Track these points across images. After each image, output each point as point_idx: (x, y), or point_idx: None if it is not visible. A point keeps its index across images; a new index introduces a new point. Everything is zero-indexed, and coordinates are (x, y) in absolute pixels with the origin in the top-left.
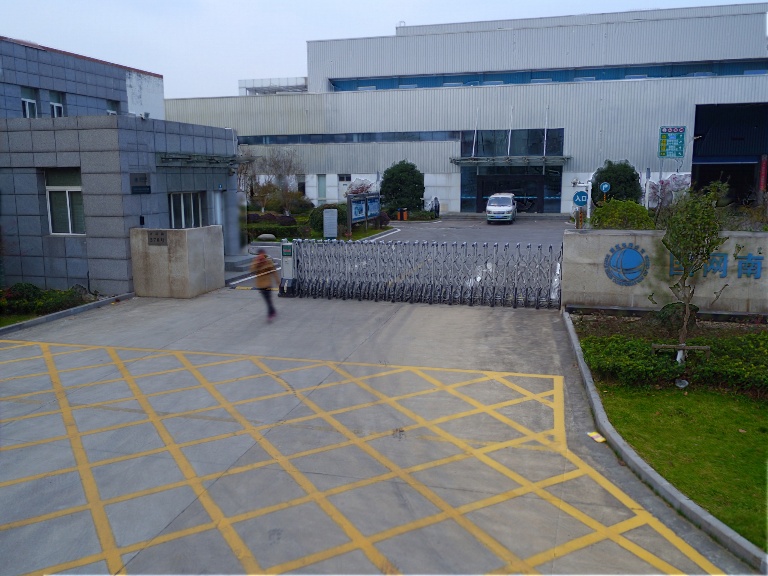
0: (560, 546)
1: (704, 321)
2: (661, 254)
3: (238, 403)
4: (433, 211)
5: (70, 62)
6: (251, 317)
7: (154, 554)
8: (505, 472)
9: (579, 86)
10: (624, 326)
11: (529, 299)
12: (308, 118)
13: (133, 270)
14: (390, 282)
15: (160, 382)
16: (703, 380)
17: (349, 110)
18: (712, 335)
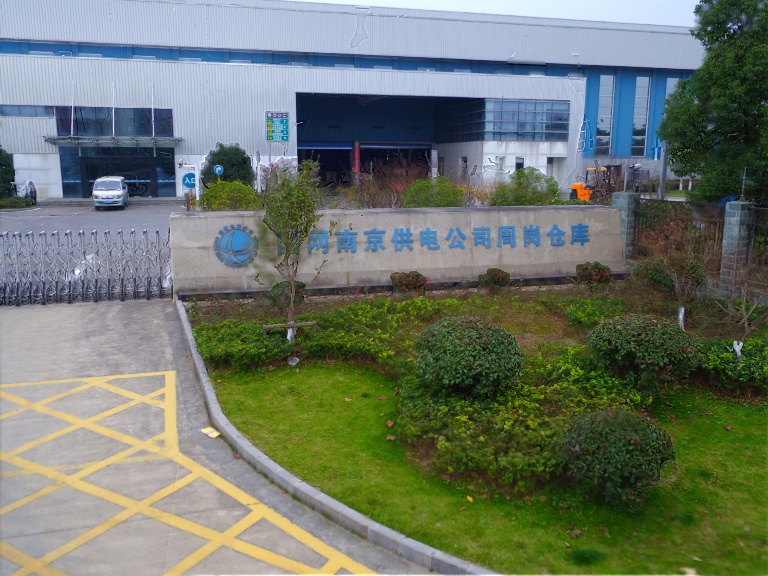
0: (169, 571)
1: (312, 296)
2: (268, 234)
3: None
4: (28, 197)
5: None
6: None
7: None
8: (105, 496)
9: (184, 66)
10: (237, 309)
11: (138, 290)
12: None
13: None
14: None
15: None
16: (312, 355)
17: None
18: (319, 309)
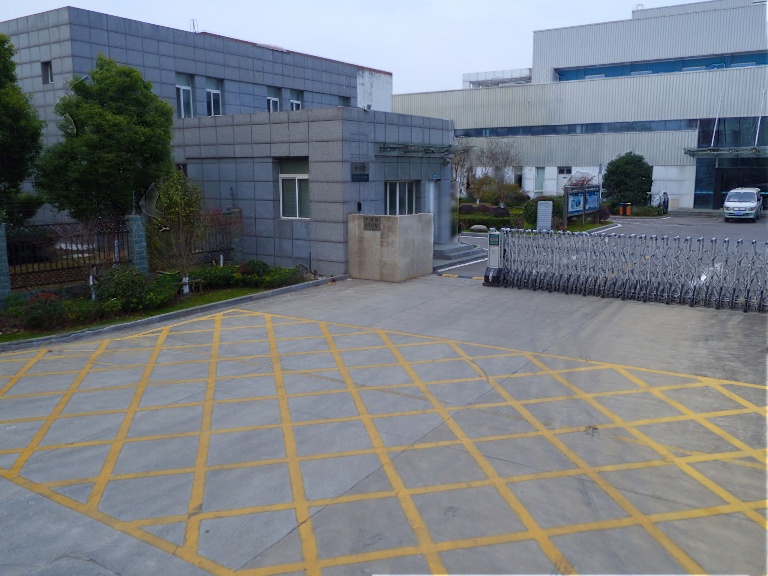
0: None
1: None
2: None
3: (431, 383)
4: (661, 206)
5: (309, 62)
6: (454, 303)
7: (337, 511)
8: (710, 486)
9: None
10: None
11: (764, 303)
12: (530, 109)
13: (349, 253)
14: (601, 276)
15: (362, 357)
16: None
17: (573, 100)
18: None
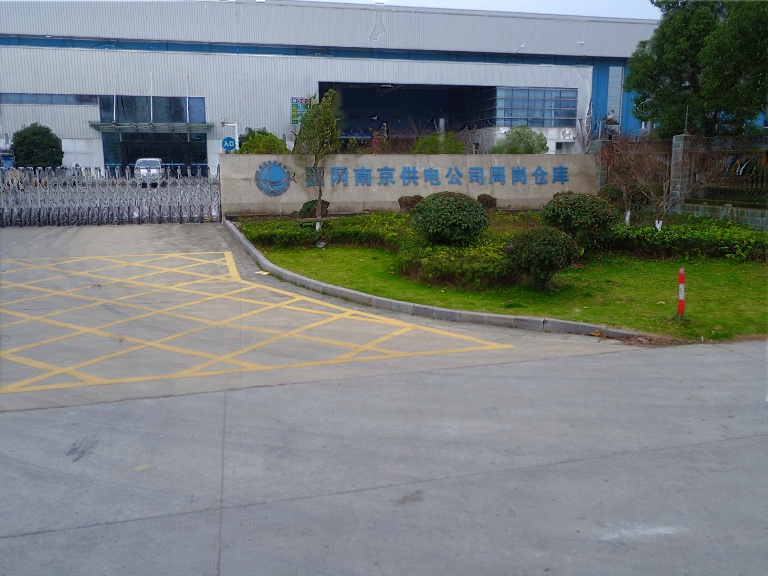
0: (245, 313)
1: None
2: (299, 169)
3: None
4: None
5: None
6: None
7: None
8: (196, 292)
9: (215, 57)
10: (275, 218)
11: (193, 215)
12: None
13: None
14: (53, 208)
15: None
16: (335, 239)
17: None
18: None
